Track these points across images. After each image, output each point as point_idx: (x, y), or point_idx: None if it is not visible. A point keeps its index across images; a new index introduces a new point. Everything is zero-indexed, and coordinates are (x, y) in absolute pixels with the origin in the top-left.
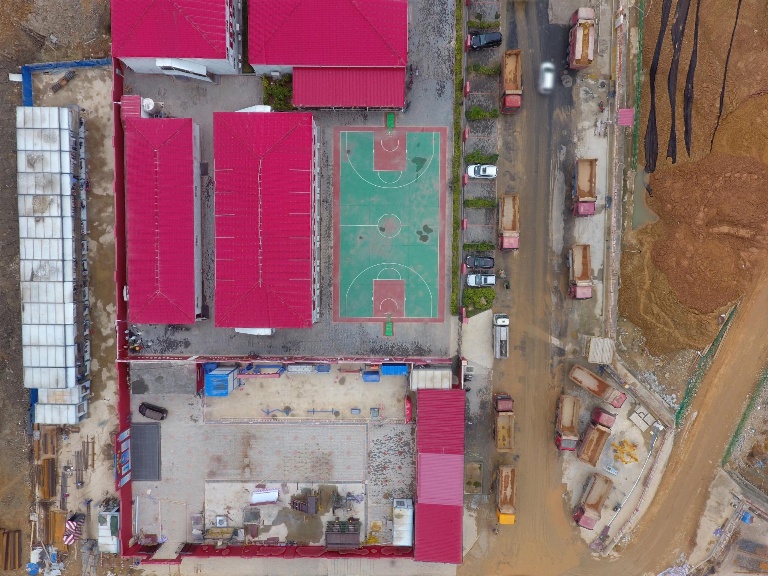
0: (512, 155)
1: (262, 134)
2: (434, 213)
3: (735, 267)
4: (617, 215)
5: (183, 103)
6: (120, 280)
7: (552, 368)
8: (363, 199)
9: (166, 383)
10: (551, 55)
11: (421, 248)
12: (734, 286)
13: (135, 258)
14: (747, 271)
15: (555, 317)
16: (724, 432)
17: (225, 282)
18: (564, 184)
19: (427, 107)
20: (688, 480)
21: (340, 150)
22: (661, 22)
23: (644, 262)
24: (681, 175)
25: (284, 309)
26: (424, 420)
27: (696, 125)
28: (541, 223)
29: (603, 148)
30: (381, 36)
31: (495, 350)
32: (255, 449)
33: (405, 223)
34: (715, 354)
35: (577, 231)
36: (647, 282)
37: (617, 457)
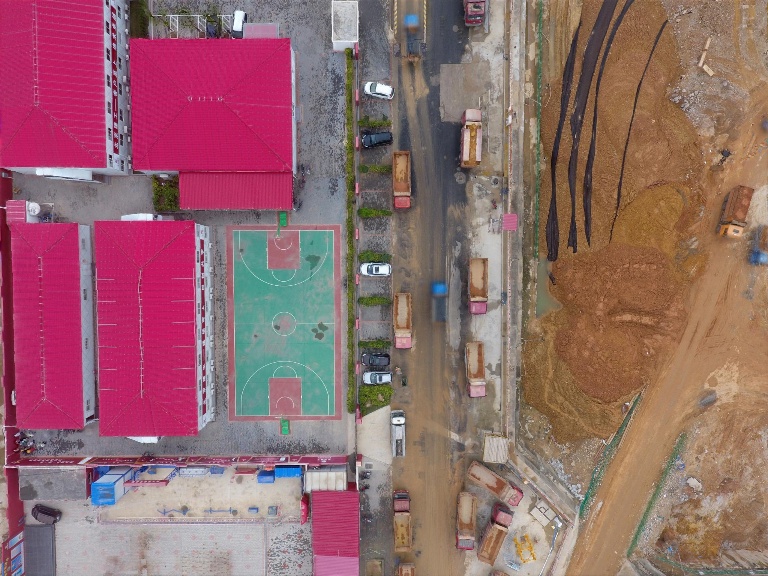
0: (407, 252)
1: (143, 244)
2: (329, 311)
3: (638, 355)
4: (513, 311)
5: (74, 204)
6: (9, 384)
7: (452, 463)
8: (257, 297)
9: (55, 489)
10: (444, 152)
11: (317, 346)
12: (636, 375)
13: (21, 364)
14: (651, 358)
15: (454, 412)
16: (630, 521)
17: (108, 392)
18: (460, 280)
19: (320, 205)
20: (593, 572)
21: (233, 249)
22: (560, 112)
23: (547, 351)
24: (581, 265)
25: (168, 418)
26: (318, 522)
27: (596, 215)
28: (438, 319)
29: (498, 244)
30: (264, 143)
31: (392, 448)
32: (152, 550)
33: (300, 321)
34: (619, 443)
35: (474, 326)
36: (551, 371)
37: (518, 553)
